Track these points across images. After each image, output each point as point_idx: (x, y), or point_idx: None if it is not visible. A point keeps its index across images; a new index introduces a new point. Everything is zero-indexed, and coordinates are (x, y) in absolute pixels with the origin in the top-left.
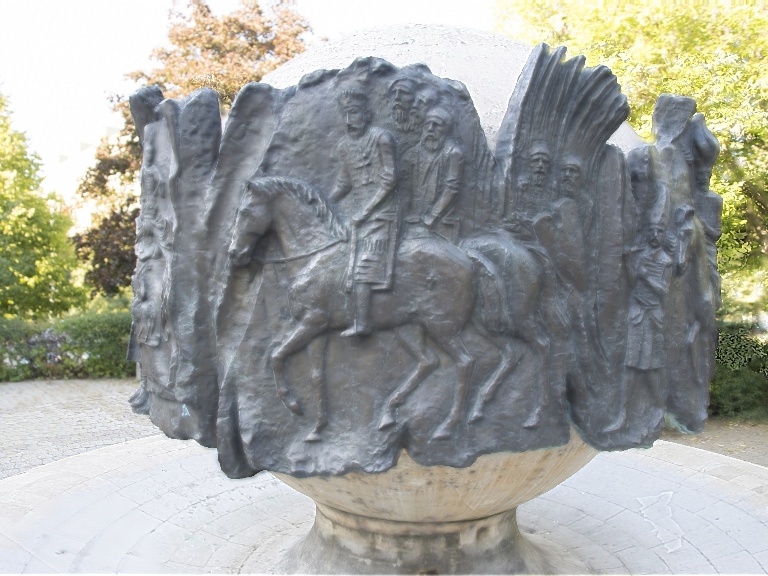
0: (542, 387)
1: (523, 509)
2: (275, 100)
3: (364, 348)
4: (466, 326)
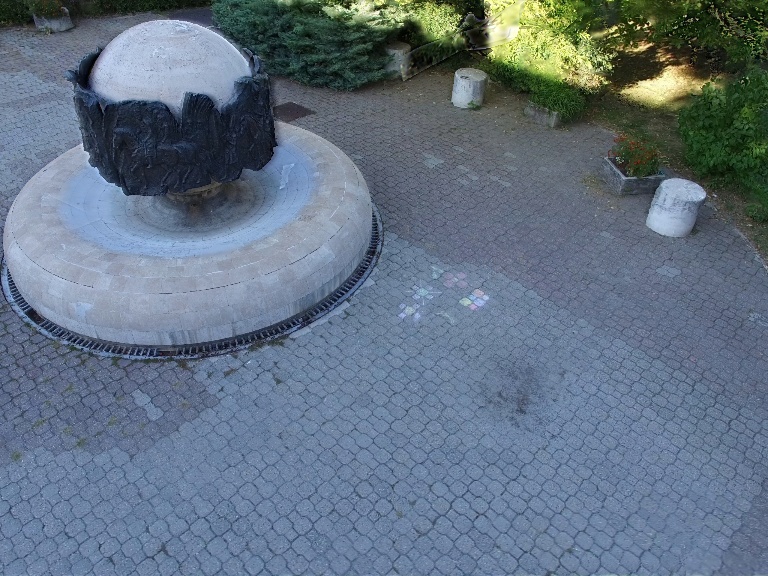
0: (200, 174)
1: (245, 170)
2: (116, 107)
3: (154, 169)
4: (178, 163)
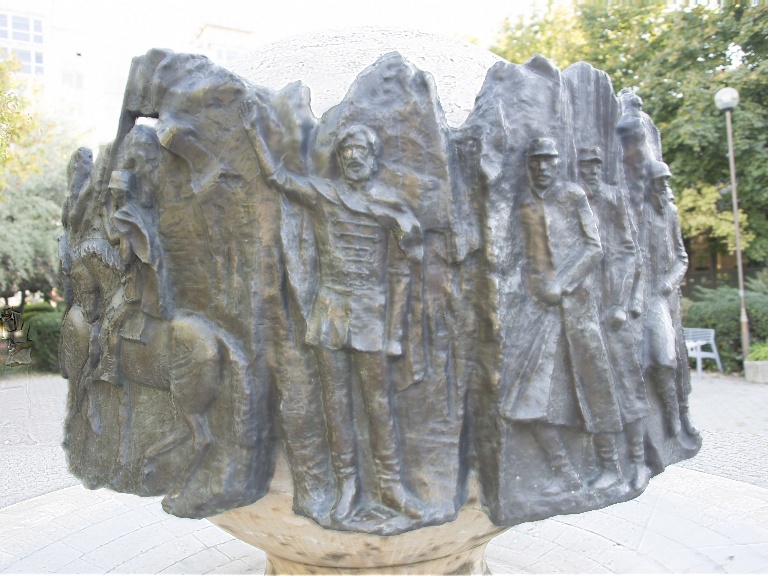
0: None
1: None
2: None
3: None
4: None
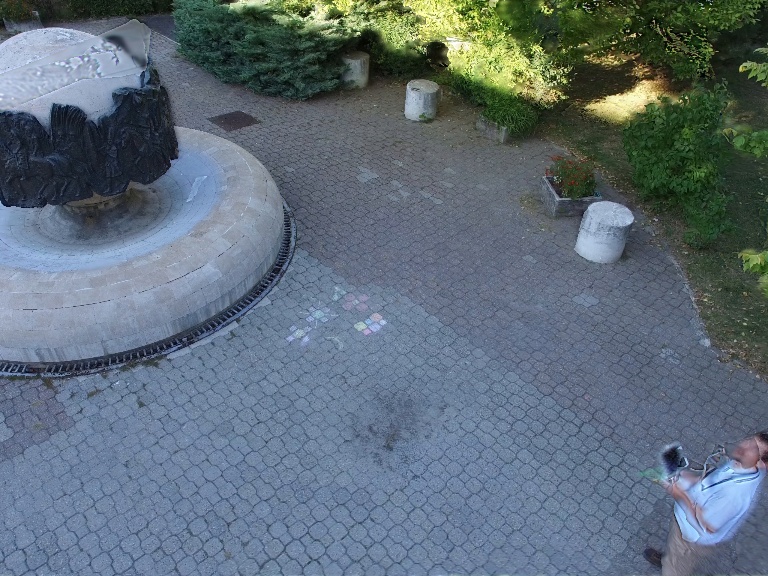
0: (78, 187)
1: (158, 181)
2: None
3: (29, 181)
4: (53, 175)
